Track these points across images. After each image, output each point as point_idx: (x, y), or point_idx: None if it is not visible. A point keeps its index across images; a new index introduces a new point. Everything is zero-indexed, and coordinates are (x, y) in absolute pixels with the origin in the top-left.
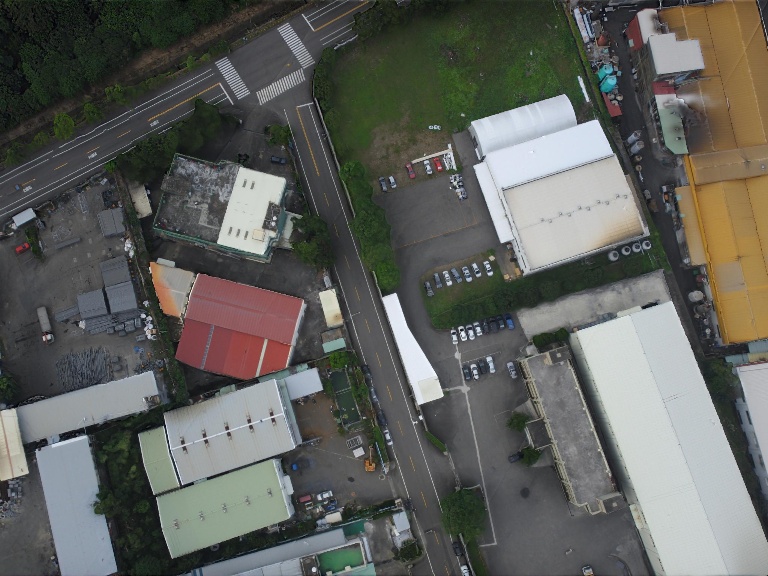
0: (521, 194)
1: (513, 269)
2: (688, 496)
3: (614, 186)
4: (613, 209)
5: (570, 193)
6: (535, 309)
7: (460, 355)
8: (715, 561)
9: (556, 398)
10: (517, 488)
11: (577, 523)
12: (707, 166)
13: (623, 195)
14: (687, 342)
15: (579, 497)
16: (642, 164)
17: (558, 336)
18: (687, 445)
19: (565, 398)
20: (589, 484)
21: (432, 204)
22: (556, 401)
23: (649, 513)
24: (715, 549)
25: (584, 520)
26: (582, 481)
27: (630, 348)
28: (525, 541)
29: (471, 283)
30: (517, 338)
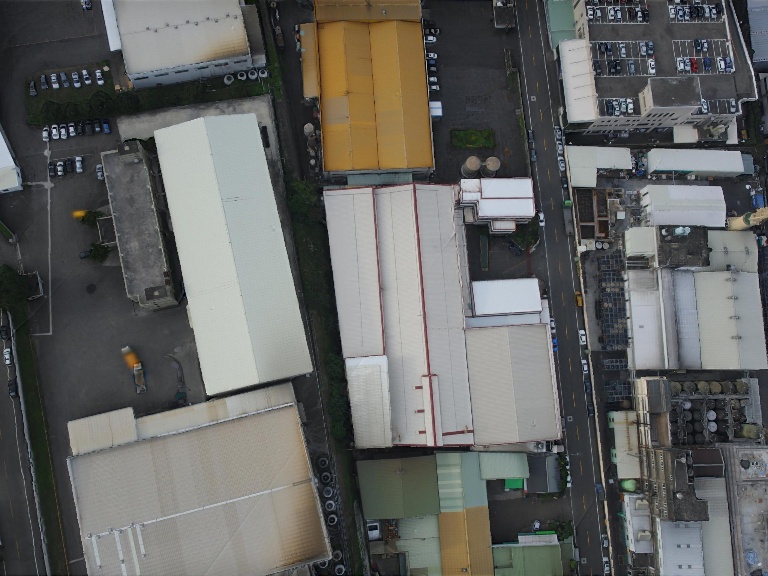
0: (132, 3)
1: (126, 81)
2: (231, 292)
3: (227, 6)
4: (221, 27)
5: (181, 7)
6: (135, 117)
7: (50, 153)
8: (246, 354)
9: (126, 194)
10: (84, 284)
11: (139, 322)
12: (329, 4)
13: (233, 15)
14: (262, 153)
15: (132, 290)
16: (280, 3)
17: (147, 141)
18: (239, 244)
19: (136, 195)
20: (145, 278)
21: (53, 10)
22: (126, 197)
23: (194, 307)
24: (247, 343)
25: (147, 320)
26: (138, 275)
27: (199, 149)
28: (82, 334)
29: (80, 89)
30: (112, 143)
